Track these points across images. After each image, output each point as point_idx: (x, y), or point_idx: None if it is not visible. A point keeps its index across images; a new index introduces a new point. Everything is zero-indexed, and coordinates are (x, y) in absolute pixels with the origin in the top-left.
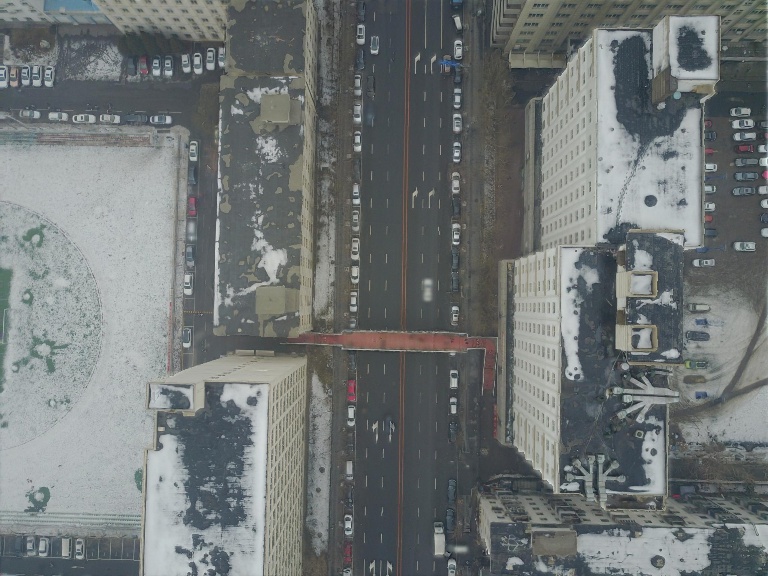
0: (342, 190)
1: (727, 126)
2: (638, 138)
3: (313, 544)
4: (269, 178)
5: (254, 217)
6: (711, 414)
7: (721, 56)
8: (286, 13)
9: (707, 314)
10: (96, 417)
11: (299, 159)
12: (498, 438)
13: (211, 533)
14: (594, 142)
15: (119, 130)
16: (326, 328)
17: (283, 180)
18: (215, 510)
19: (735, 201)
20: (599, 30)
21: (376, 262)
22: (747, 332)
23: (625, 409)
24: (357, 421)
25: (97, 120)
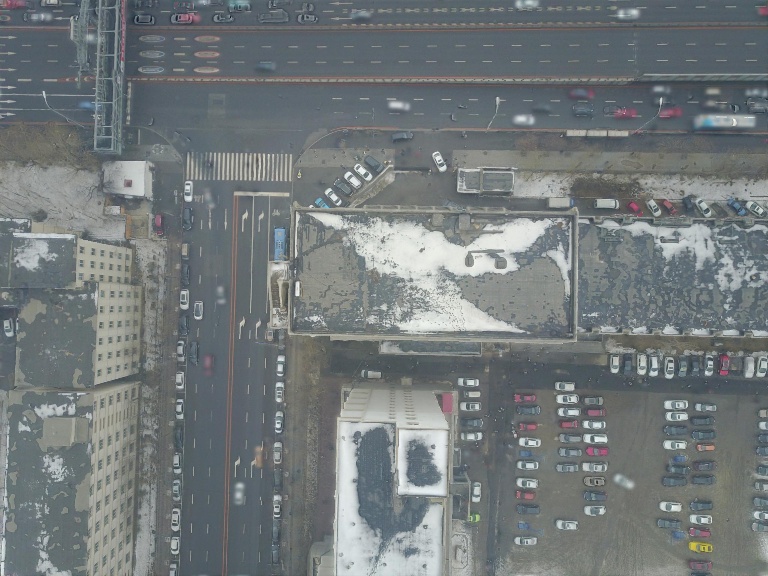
0: (164, 459)
1: (552, 399)
2: (380, 533)
3: None
4: (55, 497)
5: (40, 538)
6: None
7: None
8: (76, 327)
9: None
10: None
11: (86, 478)
12: None
13: None
14: None
15: None
16: None
17: (69, 500)
18: None
19: (559, 476)
20: (342, 421)
21: (197, 532)
22: None
23: None
24: None
25: None
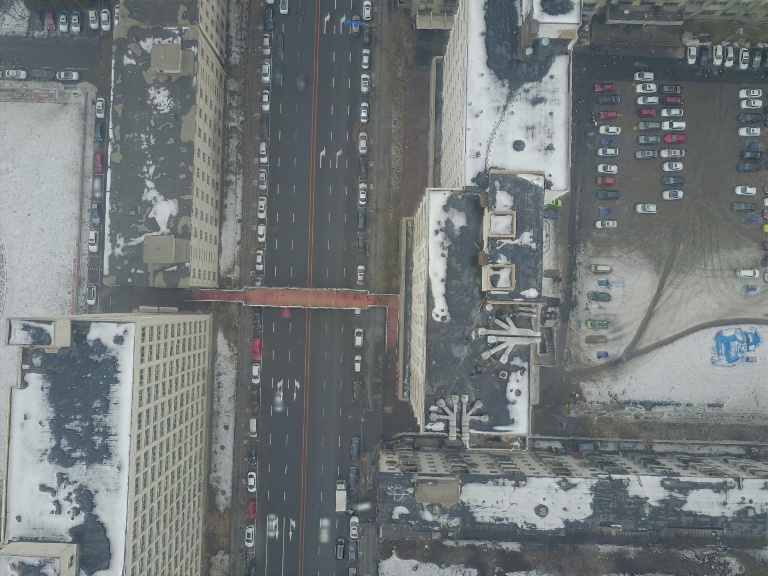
0: (250, 149)
1: (631, 90)
2: (507, 83)
3: (216, 501)
4: (161, 128)
5: (145, 167)
6: (612, 373)
7: (623, 19)
8: None
9: (609, 275)
10: None
11: (191, 110)
12: (398, 394)
13: (76, 471)
14: (464, 86)
15: (25, 86)
16: (232, 286)
17: (175, 131)
18: (80, 449)
19: (638, 164)
20: None
21: (283, 221)
22: (648, 293)
23: (489, 350)
24: (262, 379)
25: (3, 75)
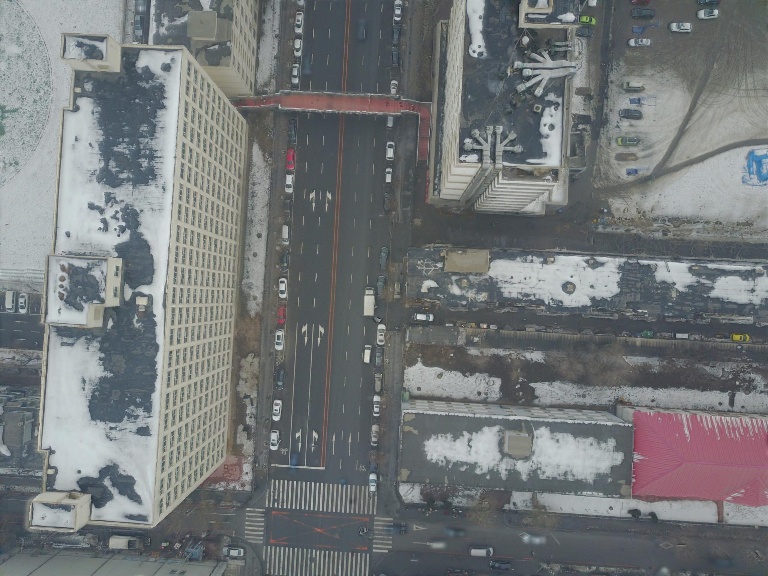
0: None
1: None
2: None
3: (248, 306)
4: None
5: None
6: (641, 191)
7: None
8: None
9: (641, 94)
10: (43, 179)
11: None
12: (428, 199)
13: (122, 191)
14: None
15: None
16: None
17: None
18: (127, 170)
19: None
20: None
21: (319, 36)
22: (679, 112)
23: (524, 83)
24: (295, 190)
25: None
